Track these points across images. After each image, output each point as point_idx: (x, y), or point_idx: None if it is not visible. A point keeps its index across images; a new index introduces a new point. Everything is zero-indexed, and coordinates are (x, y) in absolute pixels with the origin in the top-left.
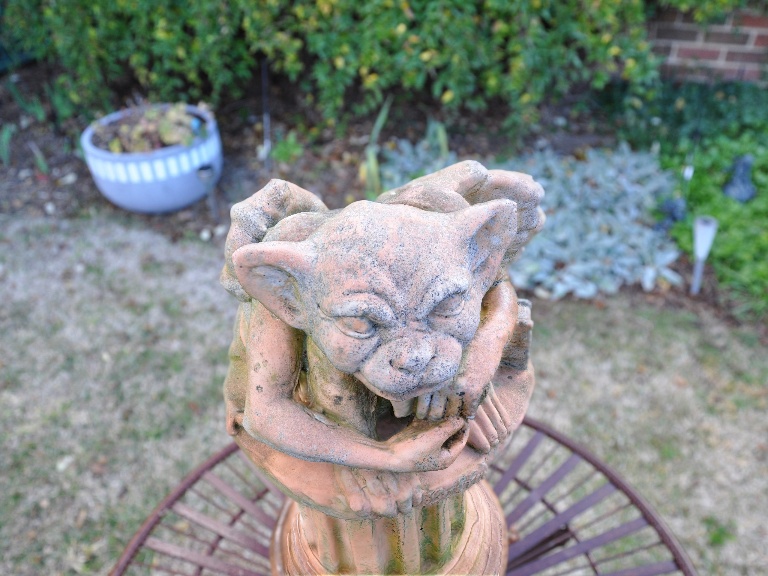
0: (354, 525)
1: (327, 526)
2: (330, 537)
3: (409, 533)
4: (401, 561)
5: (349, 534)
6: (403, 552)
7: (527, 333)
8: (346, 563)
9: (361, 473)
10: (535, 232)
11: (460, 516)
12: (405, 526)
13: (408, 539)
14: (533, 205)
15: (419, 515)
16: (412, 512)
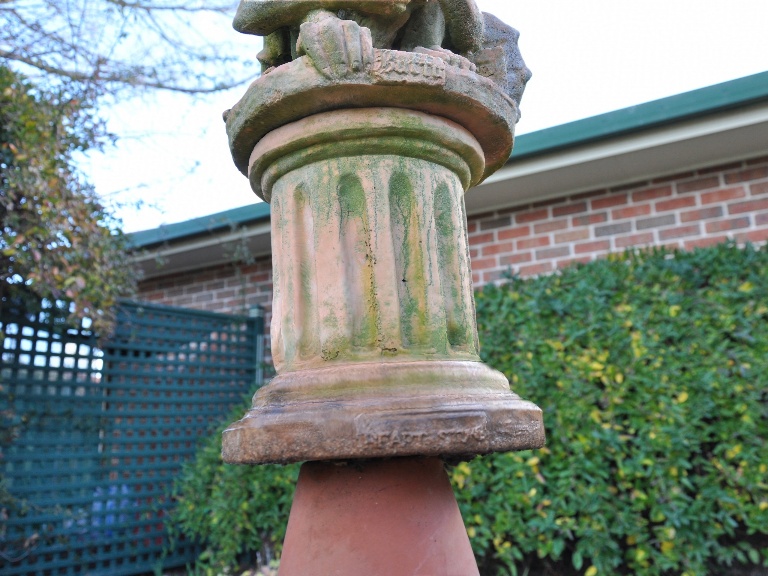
0: (320, 221)
1: (294, 253)
2: (296, 277)
3: (382, 243)
4: (374, 308)
5: (314, 242)
6: (375, 280)
7: (500, 58)
8: (310, 332)
9: (316, 17)
10: (523, 75)
11: (462, 318)
12: (377, 226)
13: (381, 255)
14: (512, 39)
15: (400, 251)
16: (385, 205)
